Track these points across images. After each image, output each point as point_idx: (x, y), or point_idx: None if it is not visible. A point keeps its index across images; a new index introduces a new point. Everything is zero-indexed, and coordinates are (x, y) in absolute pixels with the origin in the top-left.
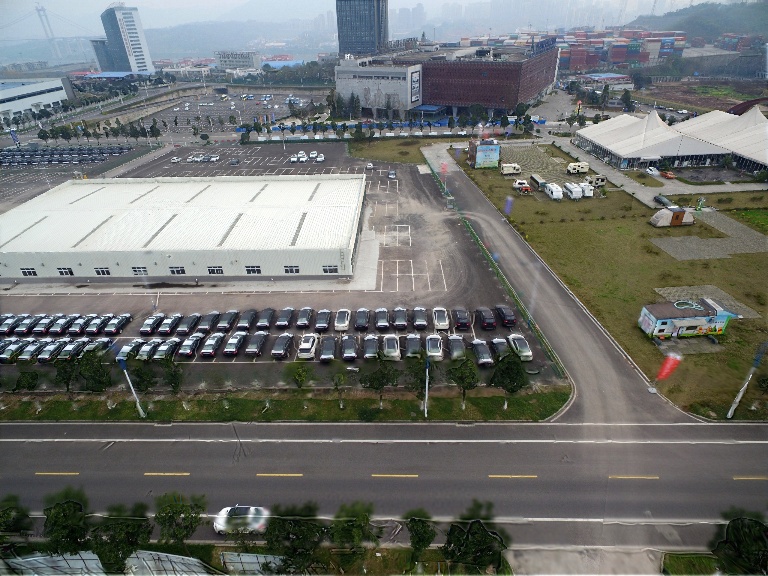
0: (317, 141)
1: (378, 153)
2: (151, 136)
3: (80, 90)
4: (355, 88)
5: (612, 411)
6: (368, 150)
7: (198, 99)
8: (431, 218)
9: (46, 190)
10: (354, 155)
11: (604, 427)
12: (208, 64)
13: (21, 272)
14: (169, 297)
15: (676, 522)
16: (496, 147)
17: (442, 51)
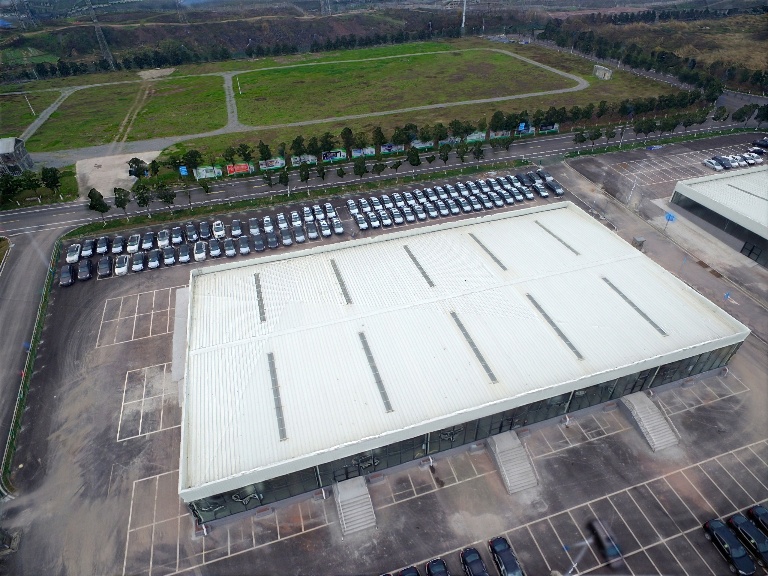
0: None
1: None
2: None
3: None
4: None
5: (48, 233)
6: None
7: None
8: (66, 482)
9: None
10: None
11: (59, 226)
12: None
13: None
14: None
15: (60, 208)
16: None
17: None
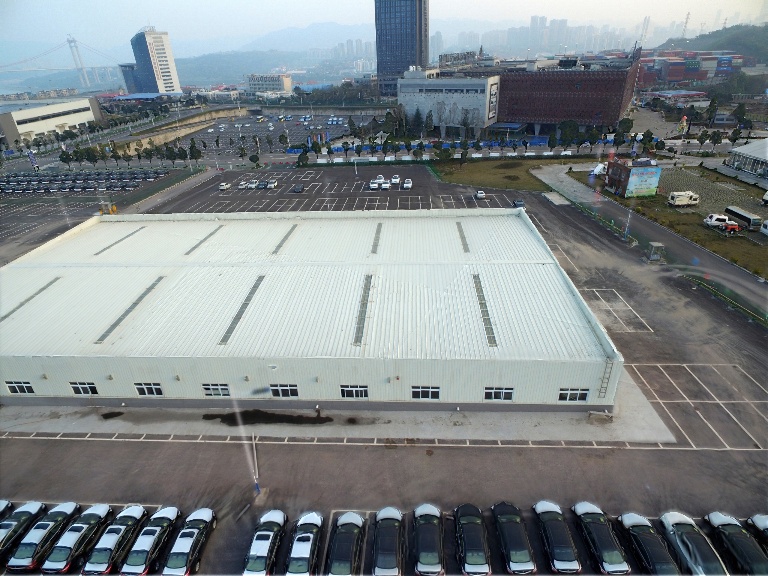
0: (390, 163)
1: (477, 177)
2: (190, 158)
3: (108, 112)
4: (421, 103)
5: None
6: (460, 174)
7: (232, 120)
8: (637, 276)
9: (64, 226)
10: (447, 180)
11: None
12: (237, 88)
13: (7, 387)
14: (276, 450)
15: None
16: (657, 169)
17: (504, 66)
